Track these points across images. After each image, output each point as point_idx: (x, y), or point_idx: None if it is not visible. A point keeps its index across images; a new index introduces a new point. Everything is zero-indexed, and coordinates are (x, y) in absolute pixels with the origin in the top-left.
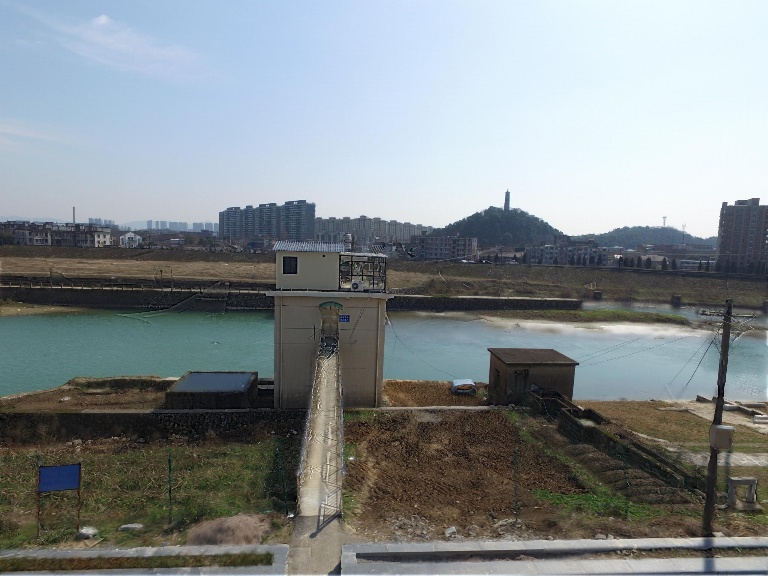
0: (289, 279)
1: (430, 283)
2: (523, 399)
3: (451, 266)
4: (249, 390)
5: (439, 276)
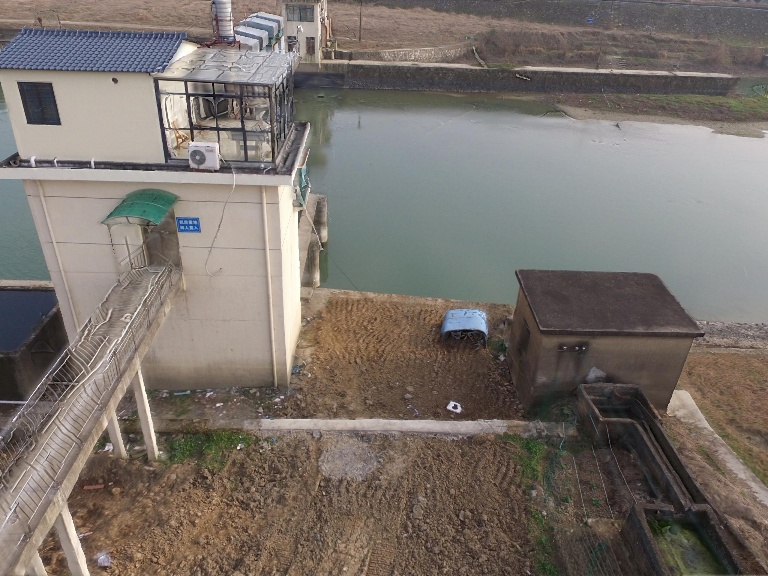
0: (46, 137)
1: (488, 37)
2: (569, 393)
3: (529, 3)
4: (39, 340)
5: (506, 22)
